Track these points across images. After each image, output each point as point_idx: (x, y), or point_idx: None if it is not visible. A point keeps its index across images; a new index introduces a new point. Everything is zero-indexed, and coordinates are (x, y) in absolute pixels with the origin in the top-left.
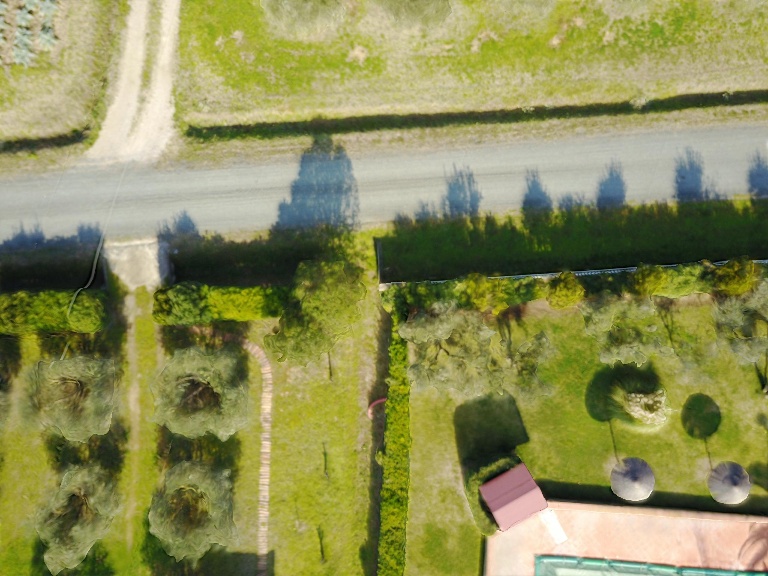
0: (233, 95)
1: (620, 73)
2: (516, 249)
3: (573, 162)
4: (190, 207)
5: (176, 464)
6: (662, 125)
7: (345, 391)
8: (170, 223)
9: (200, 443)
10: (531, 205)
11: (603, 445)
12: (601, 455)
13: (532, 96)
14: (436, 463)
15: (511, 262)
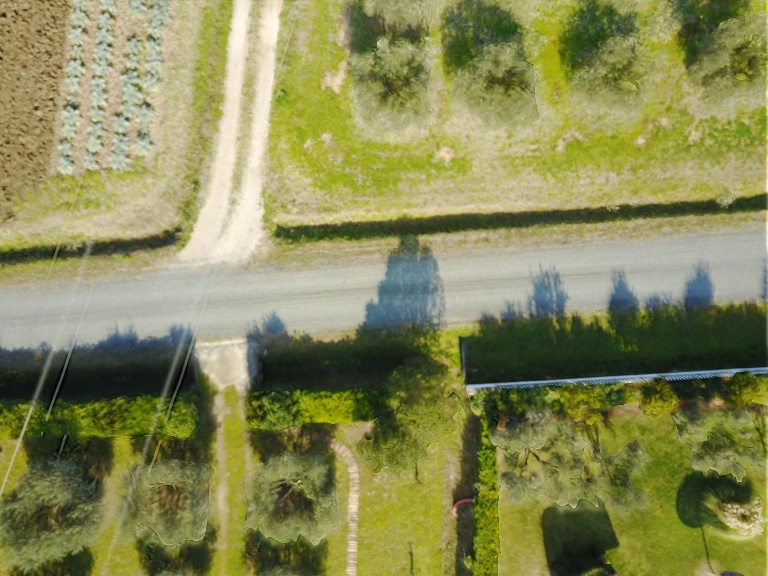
0: (320, 196)
1: (706, 172)
2: (603, 349)
3: (660, 262)
4: (279, 307)
5: (266, 565)
6: (750, 225)
7: (431, 490)
8: (259, 323)
9: (288, 542)
10: (618, 305)
11: (695, 552)
12: (693, 562)
13: (617, 195)
14: (524, 566)
15: (598, 362)
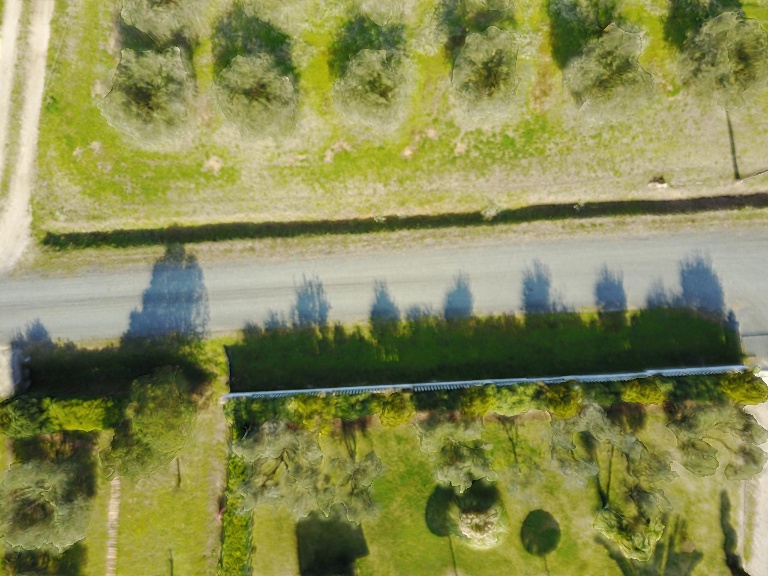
0: (90, 204)
1: (471, 184)
2: (364, 359)
3: (421, 273)
4: (44, 314)
5: (20, 571)
6: (511, 237)
7: (194, 497)
8: (24, 330)
9: (48, 548)
10: (379, 316)
11: (443, 560)
12: (441, 570)
13: (384, 206)
14: (278, 574)
15: (359, 372)
